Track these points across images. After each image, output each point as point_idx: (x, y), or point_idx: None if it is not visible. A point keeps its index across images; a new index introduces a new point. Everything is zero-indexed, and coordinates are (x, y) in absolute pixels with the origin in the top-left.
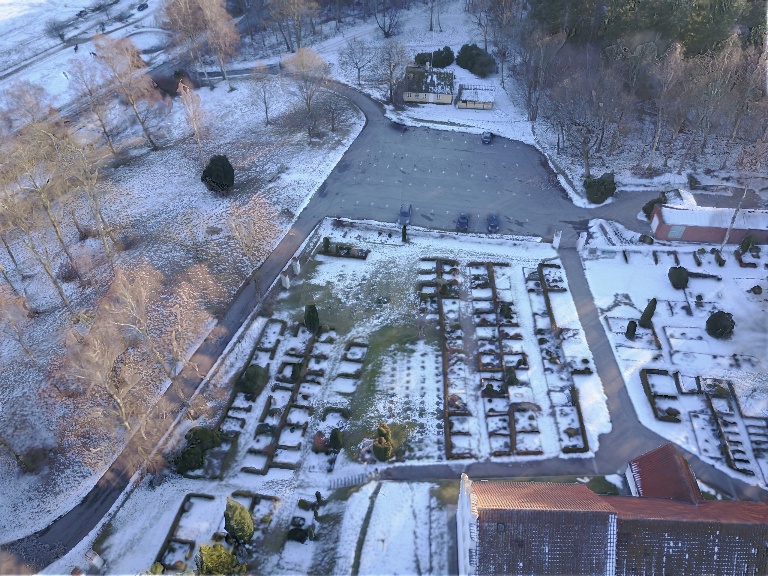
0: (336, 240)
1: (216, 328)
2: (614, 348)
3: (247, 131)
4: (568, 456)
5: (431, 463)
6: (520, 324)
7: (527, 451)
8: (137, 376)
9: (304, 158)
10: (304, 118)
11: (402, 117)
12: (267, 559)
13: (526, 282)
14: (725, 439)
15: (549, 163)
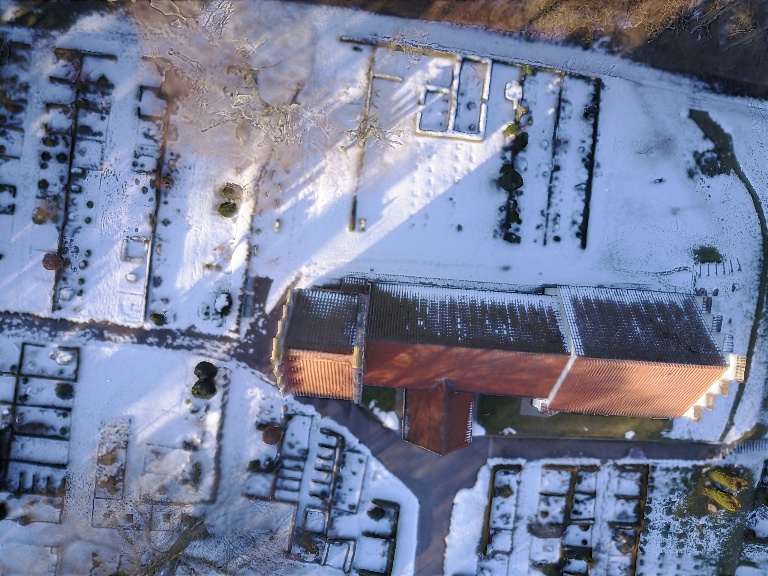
0: None
1: None
2: None
3: None
4: (517, 461)
5: (665, 462)
6: None
7: (562, 469)
8: None
9: None
10: None
11: None
12: None
13: None
14: (334, 474)
15: None
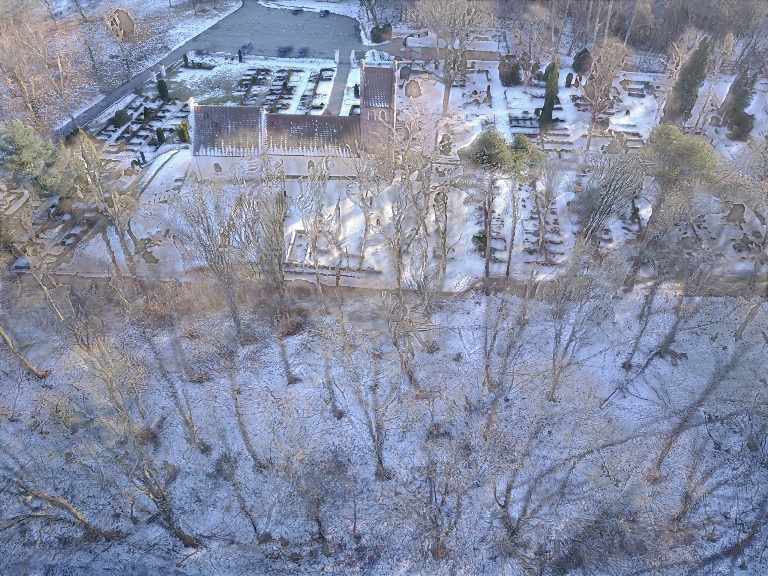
0: (195, 61)
1: (104, 99)
2: (344, 100)
3: (155, 12)
4: None
5: None
6: (295, 94)
7: None
8: (30, 61)
9: (188, 22)
10: (197, 3)
11: (269, 3)
12: (109, 182)
13: (309, 78)
14: None
15: (360, 26)
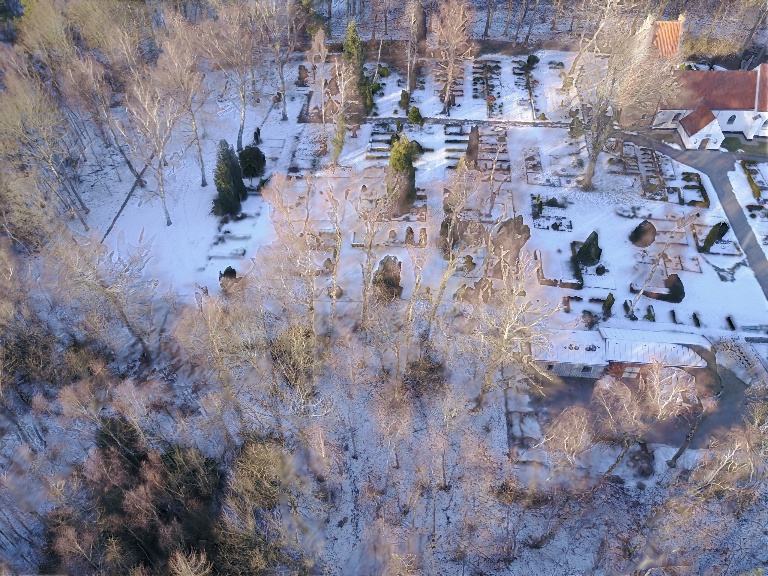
0: None
1: None
2: (731, 226)
3: None
4: None
5: None
6: None
7: None
8: None
9: None
10: None
11: None
12: None
13: None
14: (656, 162)
15: None
